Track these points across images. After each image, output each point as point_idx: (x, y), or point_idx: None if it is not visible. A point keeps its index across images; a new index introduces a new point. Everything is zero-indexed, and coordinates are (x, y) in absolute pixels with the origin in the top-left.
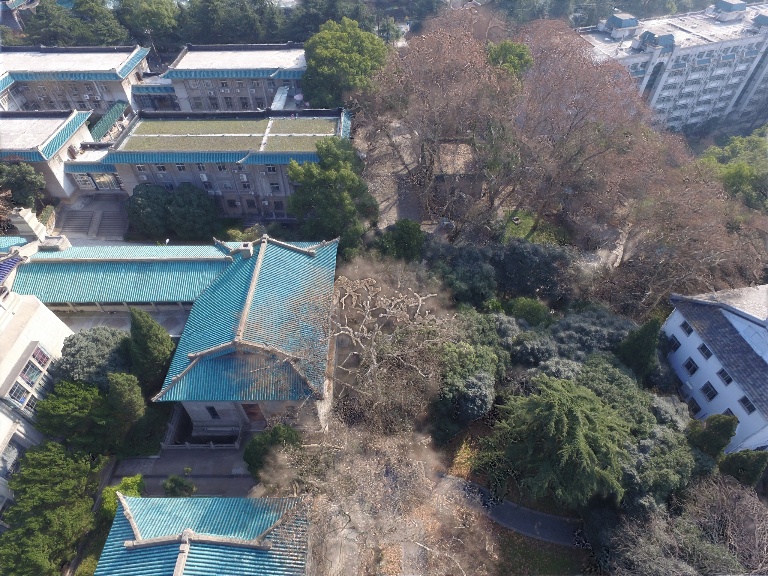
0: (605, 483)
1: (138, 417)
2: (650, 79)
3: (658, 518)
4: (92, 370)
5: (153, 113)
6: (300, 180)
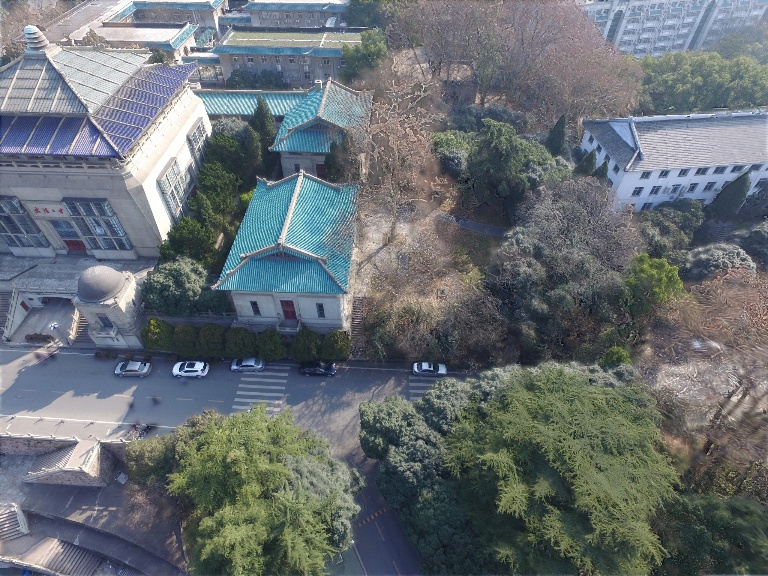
0: (521, 184)
1: (258, 162)
2: (613, 25)
3: (548, 199)
4: (234, 133)
5: (242, 27)
6: (350, 54)
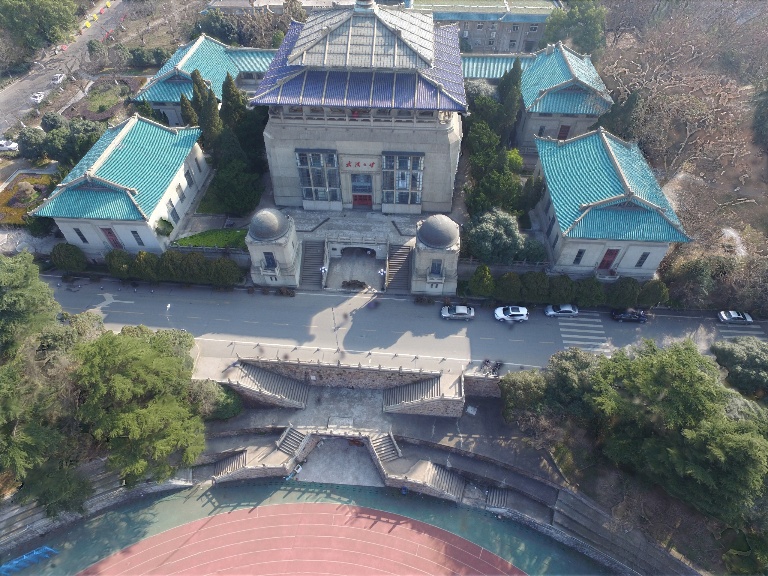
0: None
1: (512, 123)
2: None
3: None
4: (490, 94)
5: None
6: (565, 18)
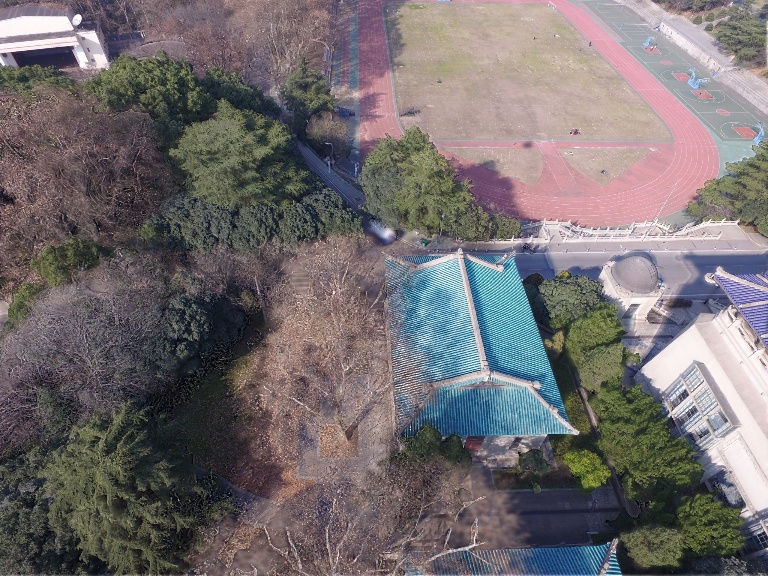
0: None
1: None
2: None
3: None
4: (724, 573)
5: None
6: None
